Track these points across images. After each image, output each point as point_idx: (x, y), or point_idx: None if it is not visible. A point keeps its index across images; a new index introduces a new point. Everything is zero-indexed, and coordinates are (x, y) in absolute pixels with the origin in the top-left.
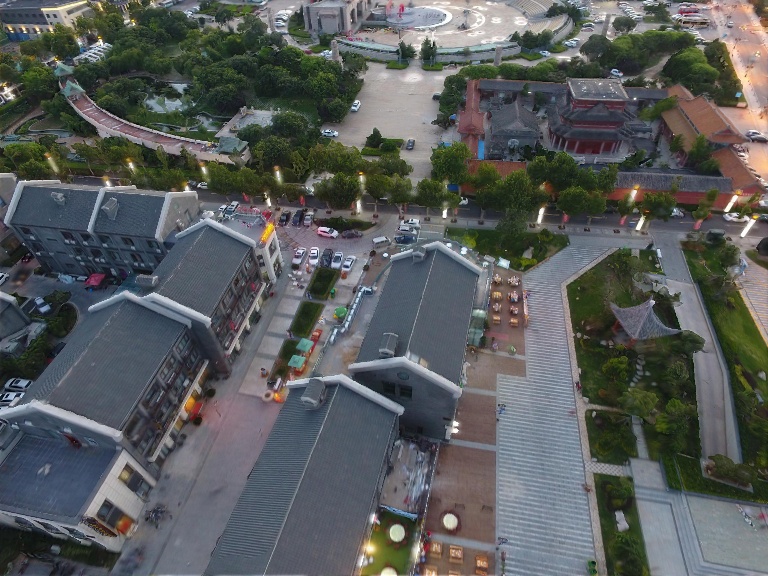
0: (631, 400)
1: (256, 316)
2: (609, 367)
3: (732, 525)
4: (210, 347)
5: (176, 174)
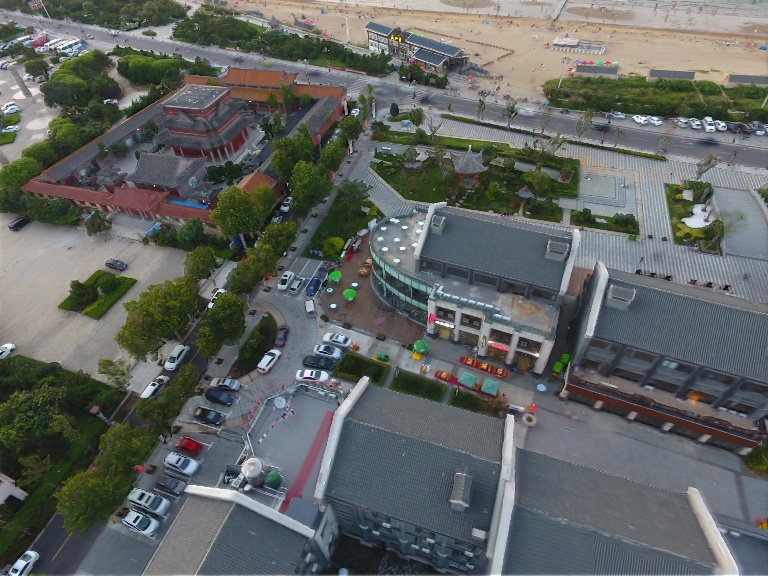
0: (541, 180)
1: None
2: (493, 195)
3: (593, 184)
4: None
5: None
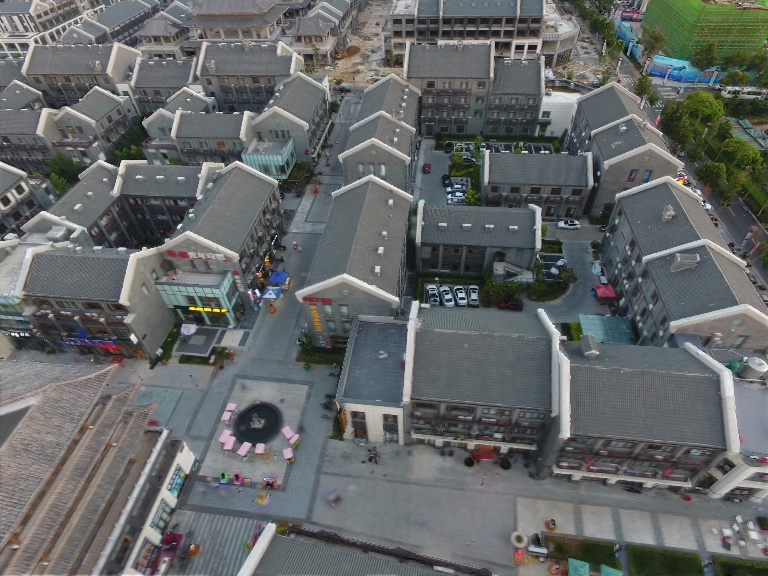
0: None
1: (636, 486)
2: None
3: None
4: (548, 446)
5: None
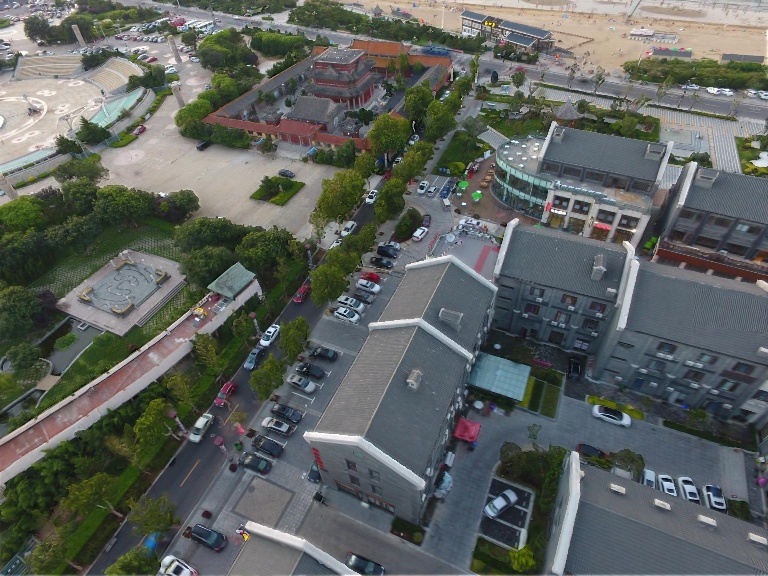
0: (631, 124)
1: None
2: None
3: None
4: None
5: (299, 321)
